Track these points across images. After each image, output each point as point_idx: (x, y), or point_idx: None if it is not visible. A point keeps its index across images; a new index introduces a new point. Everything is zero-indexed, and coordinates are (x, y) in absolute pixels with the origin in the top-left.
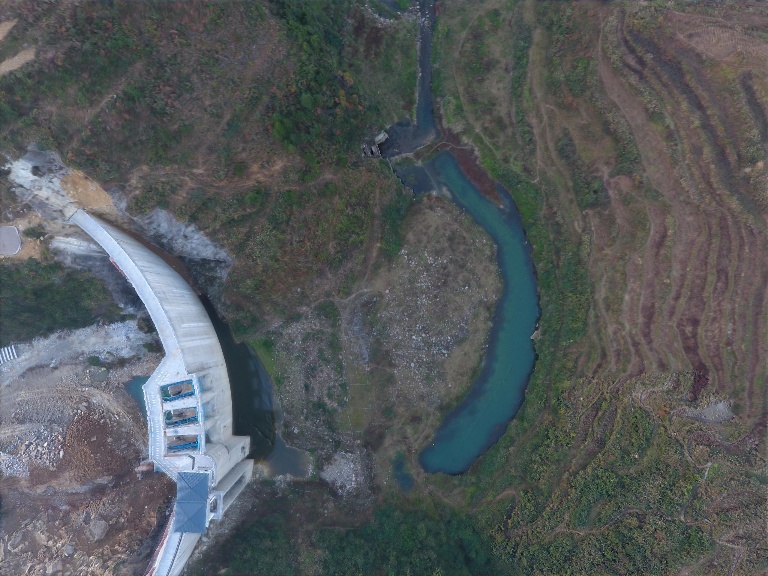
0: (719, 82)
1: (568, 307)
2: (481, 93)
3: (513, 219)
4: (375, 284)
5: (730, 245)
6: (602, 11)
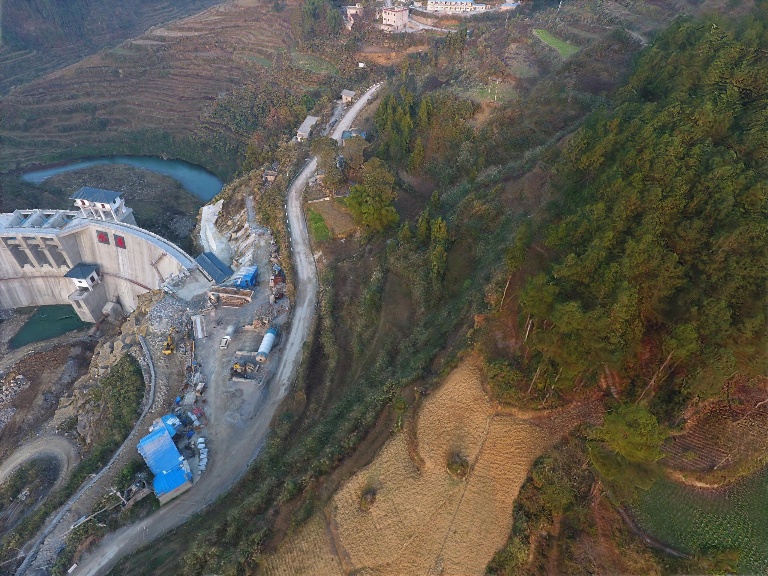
0: (74, 76)
1: (152, 138)
2: (3, 156)
3: (92, 159)
4: (72, 201)
5: (154, 87)
6: (4, 103)
